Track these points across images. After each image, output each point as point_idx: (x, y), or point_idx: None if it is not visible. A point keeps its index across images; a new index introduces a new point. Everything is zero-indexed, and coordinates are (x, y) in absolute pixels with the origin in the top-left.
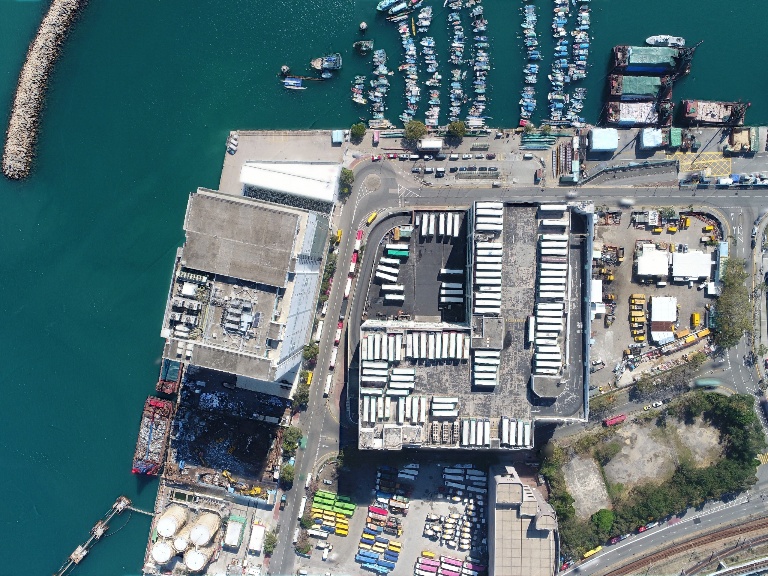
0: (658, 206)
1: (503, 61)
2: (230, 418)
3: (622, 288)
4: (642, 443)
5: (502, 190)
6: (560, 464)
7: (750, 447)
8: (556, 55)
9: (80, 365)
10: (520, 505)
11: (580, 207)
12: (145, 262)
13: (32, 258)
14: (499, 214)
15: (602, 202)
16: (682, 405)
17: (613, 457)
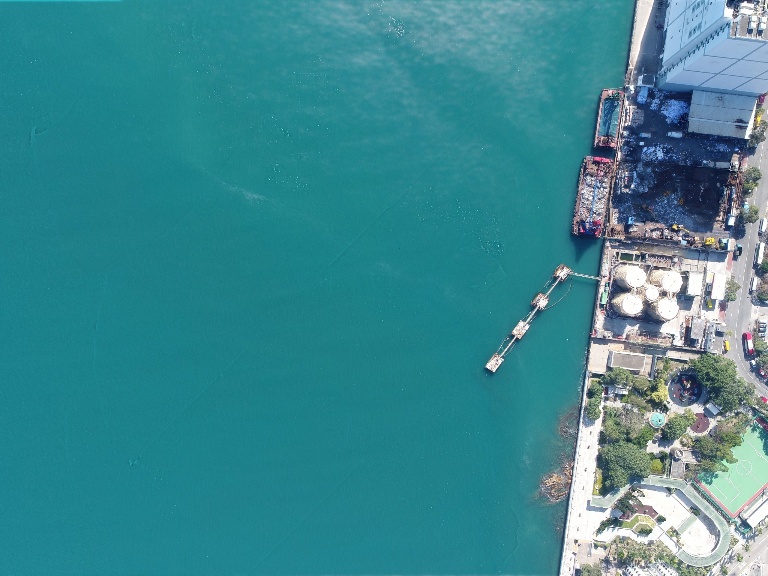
0: None
1: None
2: (679, 168)
3: None
4: None
5: None
6: None
7: None
8: None
9: (507, 133)
10: None
11: None
12: (570, 19)
13: (450, 26)
14: None
15: None
16: None
17: None
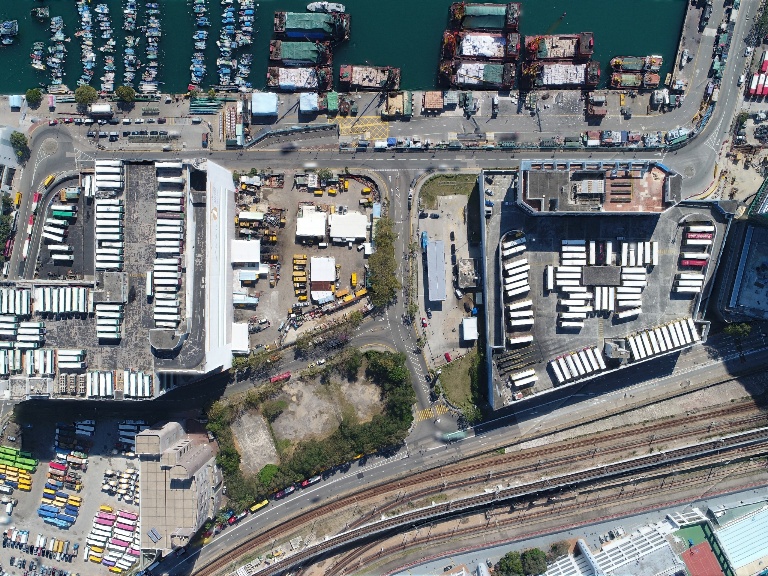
0: (320, 169)
1: (174, 27)
2: None
3: (286, 249)
4: (307, 400)
5: (172, 153)
6: (224, 420)
7: (396, 402)
8: (224, 21)
9: None
10: (160, 456)
11: (194, 165)
12: None
13: None
14: (116, 171)
15: (267, 165)
16: (344, 363)
17: (274, 413)
